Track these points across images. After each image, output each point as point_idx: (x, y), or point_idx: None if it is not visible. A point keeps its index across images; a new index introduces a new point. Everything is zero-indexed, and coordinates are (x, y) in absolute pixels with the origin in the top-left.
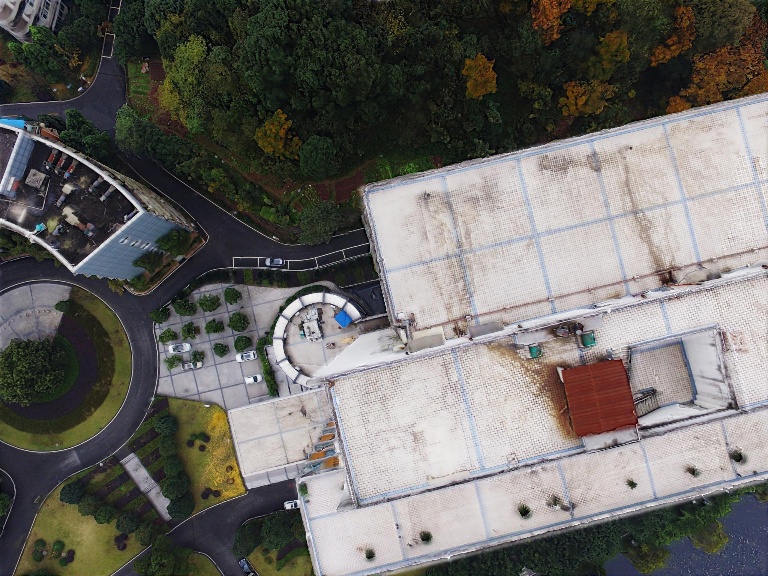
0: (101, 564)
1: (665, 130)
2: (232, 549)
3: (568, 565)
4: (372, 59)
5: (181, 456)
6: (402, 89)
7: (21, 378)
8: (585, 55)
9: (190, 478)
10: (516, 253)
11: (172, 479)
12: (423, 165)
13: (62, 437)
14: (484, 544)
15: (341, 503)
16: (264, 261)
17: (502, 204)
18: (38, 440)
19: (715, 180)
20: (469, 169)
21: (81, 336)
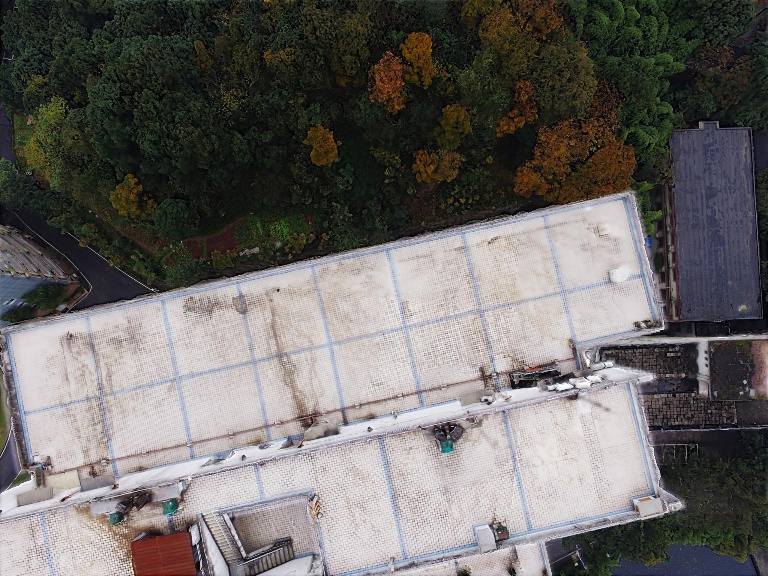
0: None
1: (313, 272)
2: None
3: None
4: (209, 130)
5: None
6: (247, 157)
7: None
8: (428, 126)
9: None
10: (157, 396)
11: None
12: (294, 223)
13: None
14: None
15: None
16: None
17: (144, 346)
18: None
19: (362, 324)
20: (113, 310)
21: None
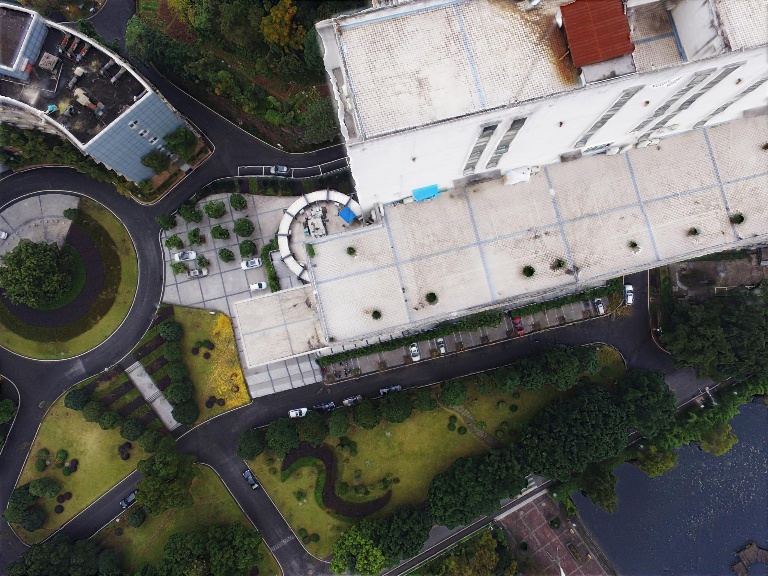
0: (104, 474)
1: None
2: (236, 452)
3: (576, 462)
4: None
5: (186, 364)
6: None
7: (29, 275)
8: None
9: (195, 386)
10: None
11: (177, 383)
12: None
13: (68, 345)
14: (490, 303)
15: None
16: (269, 169)
17: None
18: (44, 349)
19: None
20: None
21: (88, 245)
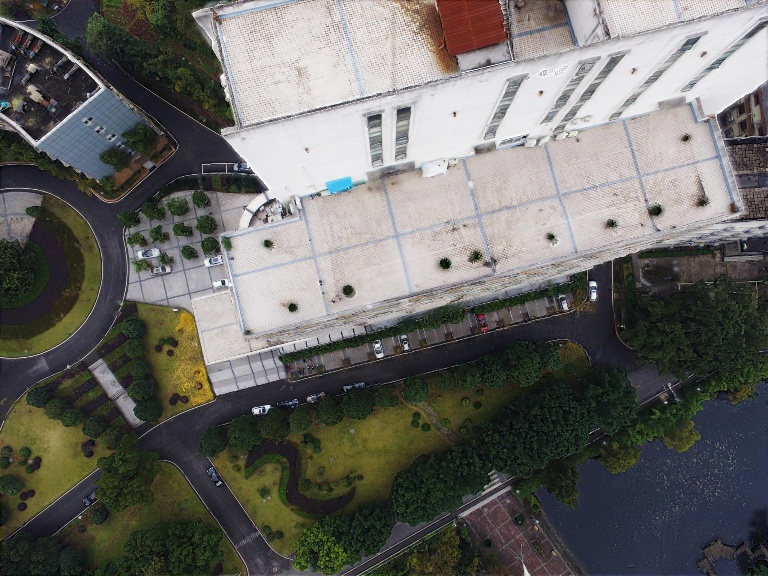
0: (67, 472)
1: None
2: (198, 449)
3: (537, 458)
4: None
5: (149, 361)
6: None
7: None
8: None
9: (158, 383)
10: None
11: (139, 380)
12: None
13: (31, 343)
14: (406, 295)
15: None
16: (232, 166)
17: None
18: (7, 346)
19: None
20: None
21: (52, 242)
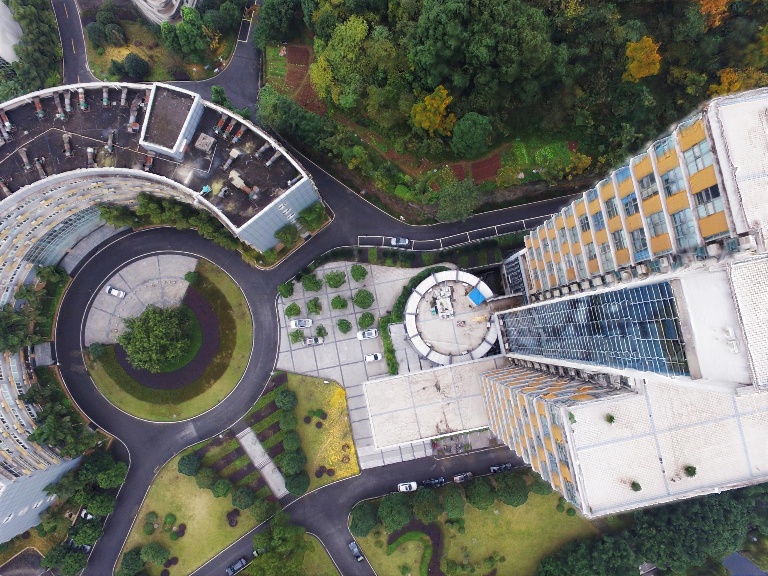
0: (211, 540)
1: None
2: (351, 528)
3: (697, 558)
4: (544, 37)
5: (298, 432)
6: None
7: (156, 343)
8: (744, 42)
9: (305, 455)
10: None
11: (292, 454)
12: (558, 150)
13: (180, 408)
14: (753, 481)
15: (735, 389)
16: (389, 240)
17: None
18: (156, 410)
19: None
20: None
21: (205, 308)
